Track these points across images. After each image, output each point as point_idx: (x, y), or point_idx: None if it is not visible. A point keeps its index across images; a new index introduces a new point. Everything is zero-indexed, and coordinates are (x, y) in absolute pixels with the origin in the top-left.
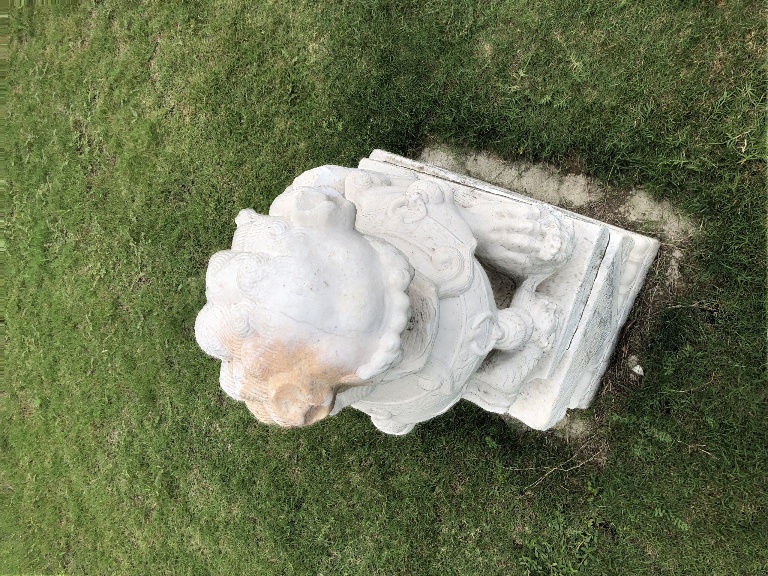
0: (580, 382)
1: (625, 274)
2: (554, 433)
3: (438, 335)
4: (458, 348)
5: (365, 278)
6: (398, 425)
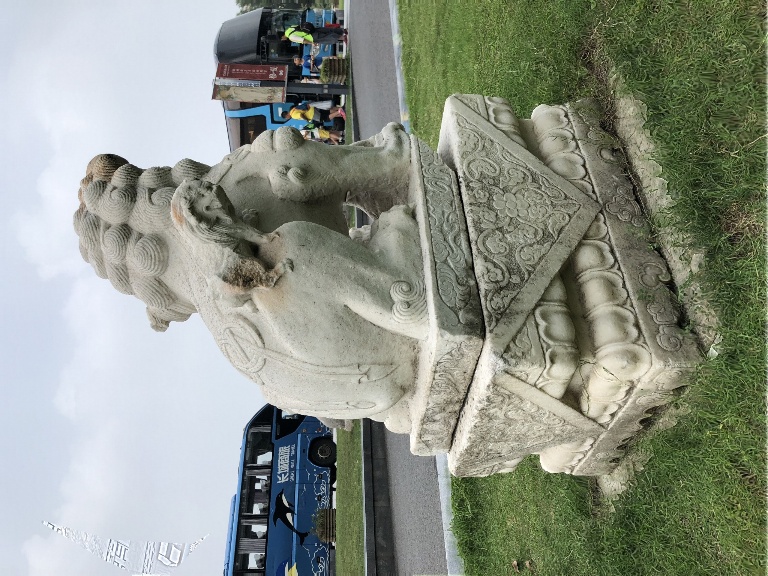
0: None
1: None
2: None
3: None
4: None
5: None
6: None
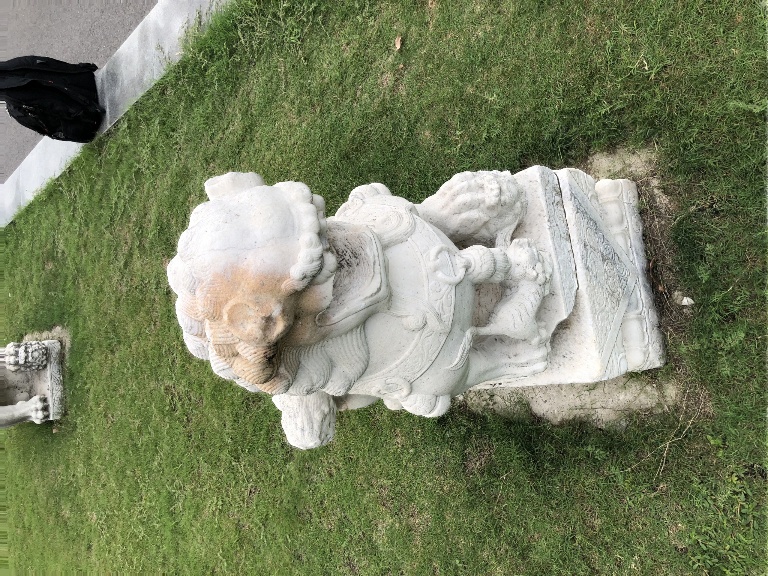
0: (630, 333)
1: (609, 215)
2: (652, 412)
3: (400, 275)
4: (425, 281)
5: (268, 201)
6: (426, 397)
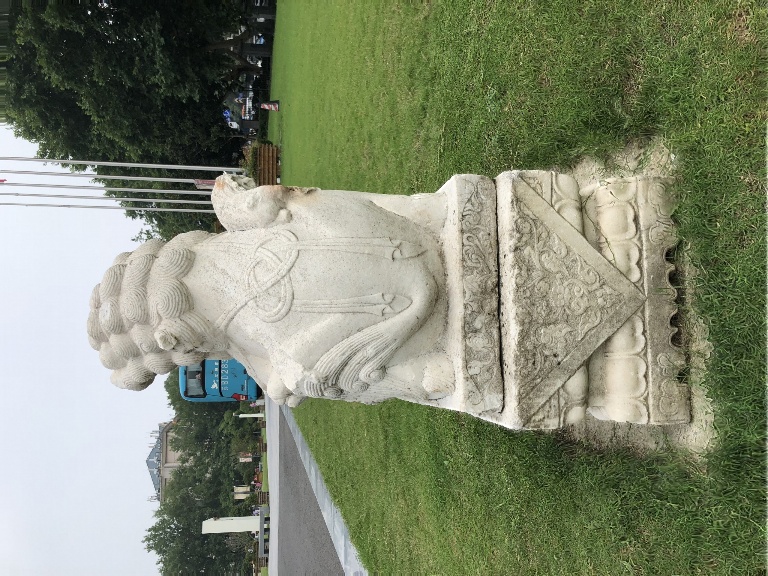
0: None
1: None
2: None
3: None
4: None
5: None
6: None
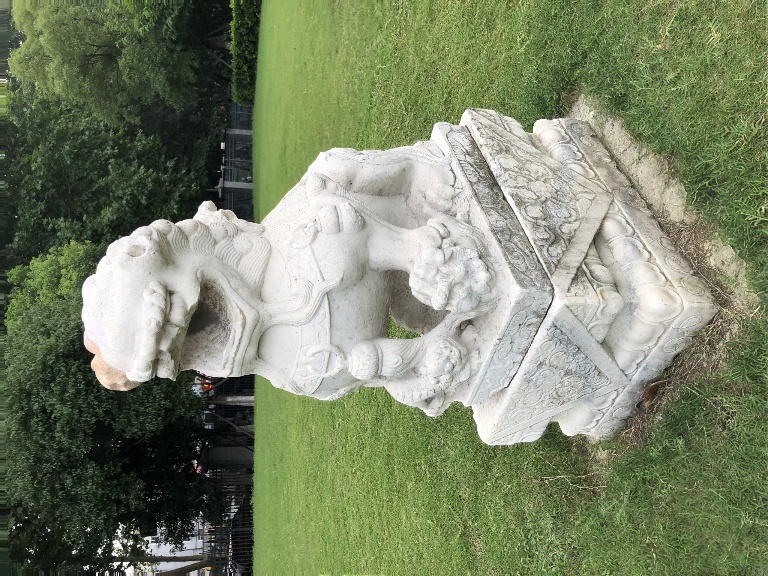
0: (574, 416)
1: (632, 332)
2: (585, 444)
3: (276, 351)
4: (295, 366)
5: (123, 319)
6: None
